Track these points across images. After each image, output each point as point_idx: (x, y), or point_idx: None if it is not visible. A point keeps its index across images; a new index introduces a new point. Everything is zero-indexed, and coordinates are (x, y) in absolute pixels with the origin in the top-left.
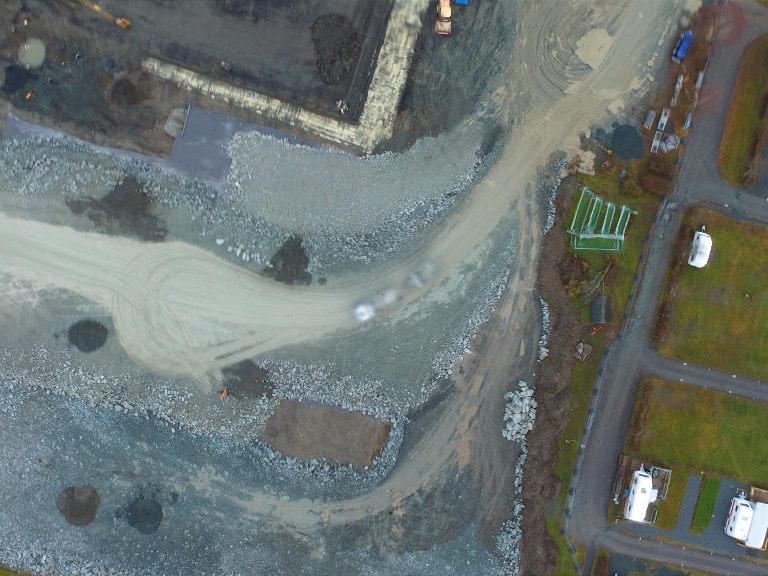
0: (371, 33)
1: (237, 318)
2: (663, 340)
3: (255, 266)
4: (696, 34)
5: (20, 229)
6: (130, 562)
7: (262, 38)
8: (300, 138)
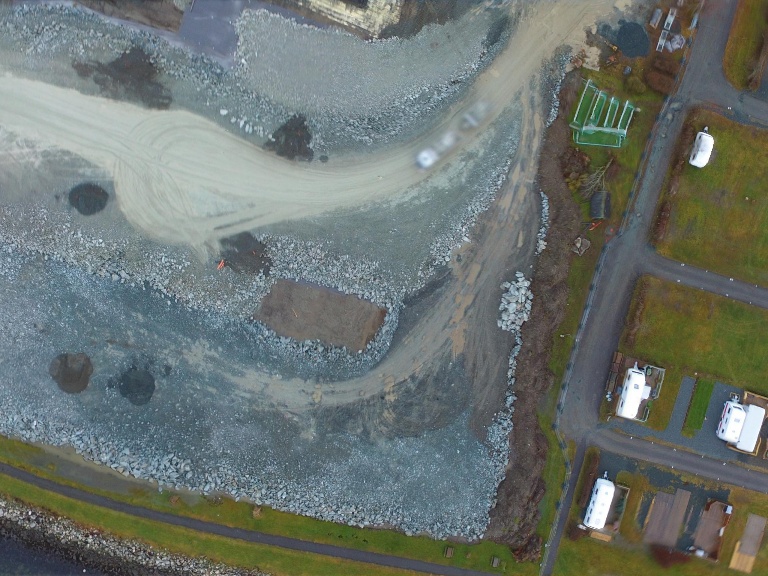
0: None
1: (237, 190)
2: (661, 238)
3: (258, 139)
4: None
5: (26, 89)
6: (120, 432)
7: None
8: (308, 18)
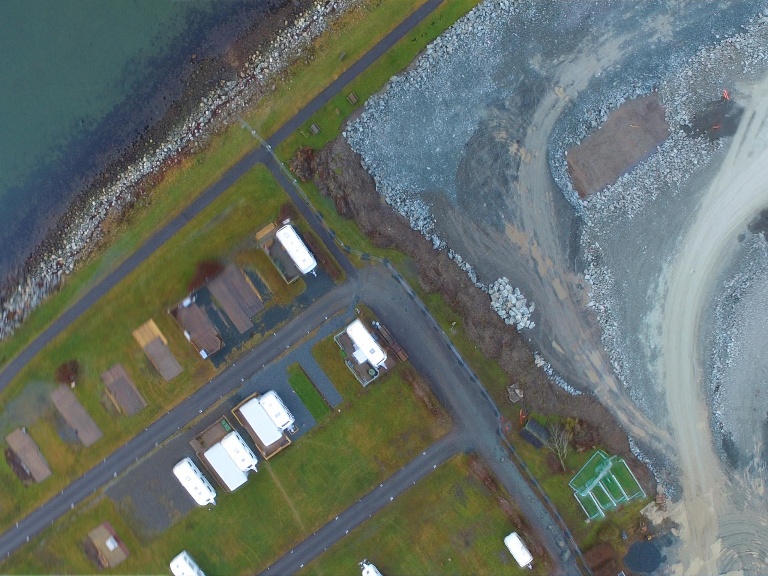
0: None
1: None
2: (474, 463)
3: None
4: None
5: None
6: None
7: None
8: None
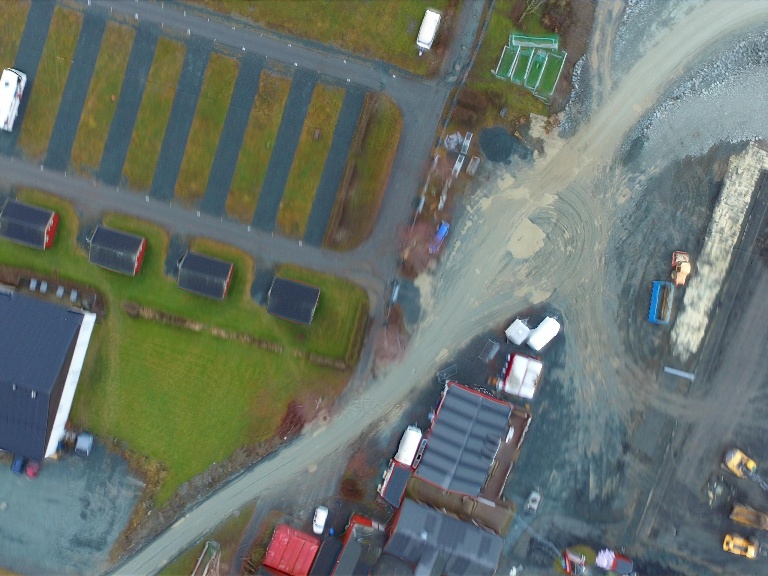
0: (747, 256)
1: None
2: None
3: None
4: (426, 249)
5: None
6: None
7: None
8: None
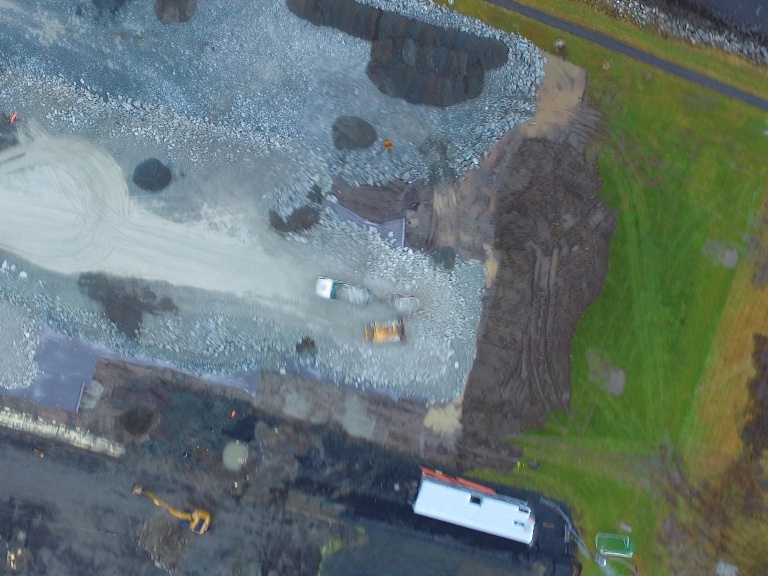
0: None
1: (7, 197)
2: None
3: None
4: None
5: (221, 281)
6: None
7: (5, 483)
8: None
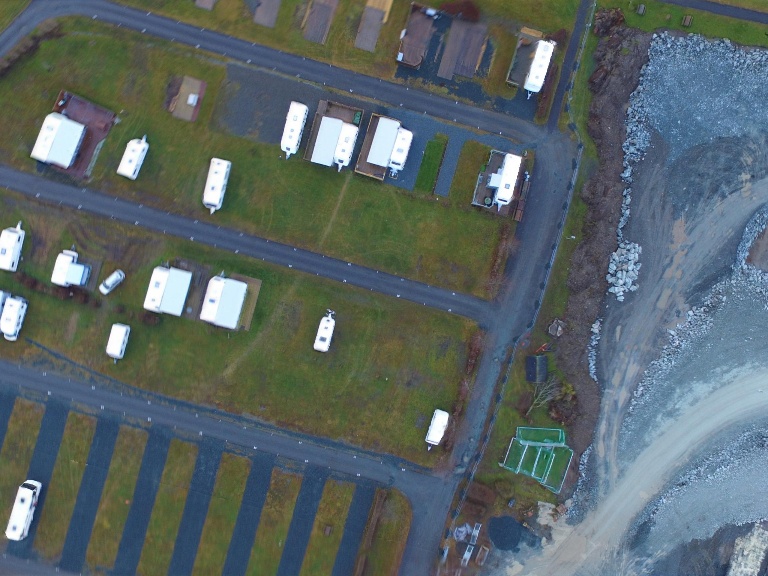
0: None
1: None
2: (478, 337)
3: None
4: None
5: None
6: None
7: None
8: None
